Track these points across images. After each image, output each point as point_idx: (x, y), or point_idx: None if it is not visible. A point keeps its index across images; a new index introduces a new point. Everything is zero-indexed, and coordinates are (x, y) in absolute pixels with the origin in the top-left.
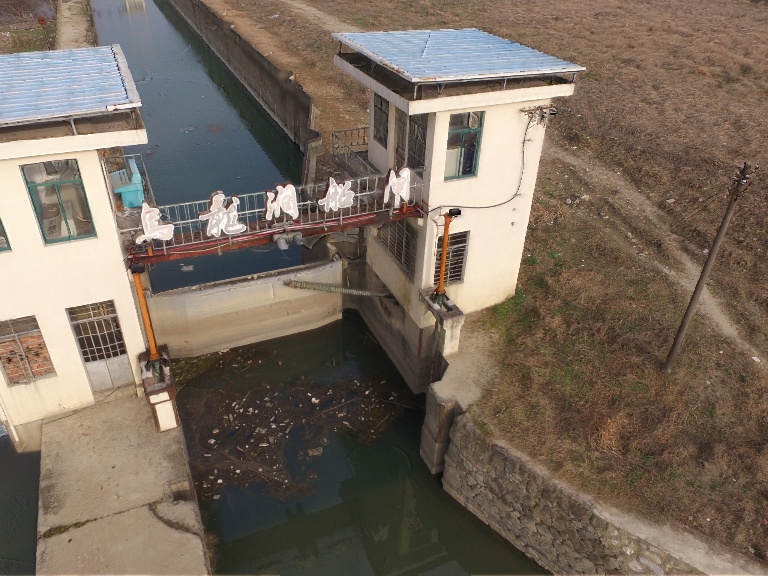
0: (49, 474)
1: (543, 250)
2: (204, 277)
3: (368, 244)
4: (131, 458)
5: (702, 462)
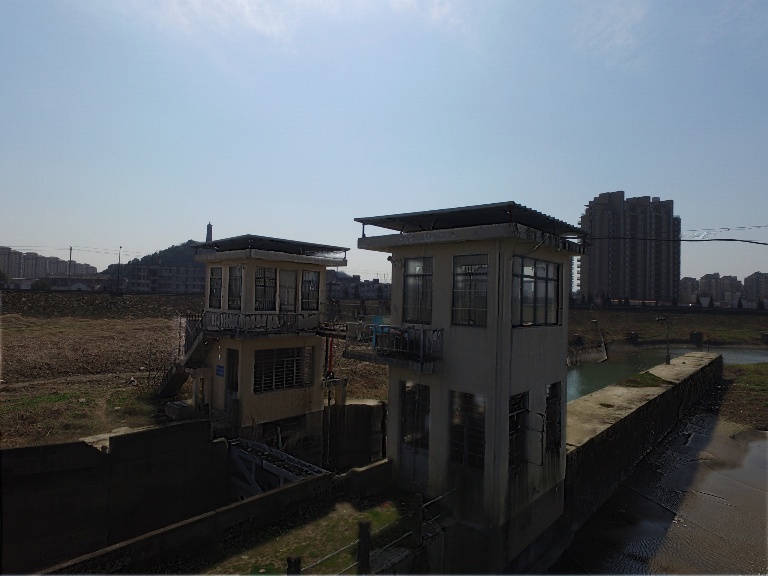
0: None
1: None
2: None
3: (247, 407)
4: None
5: None
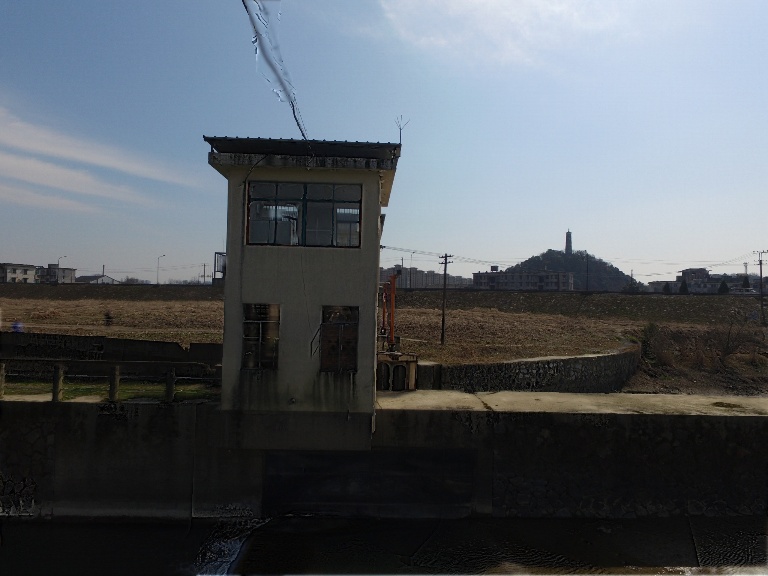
0: (437, 407)
1: None
2: None
3: None
4: (435, 395)
5: (490, 352)
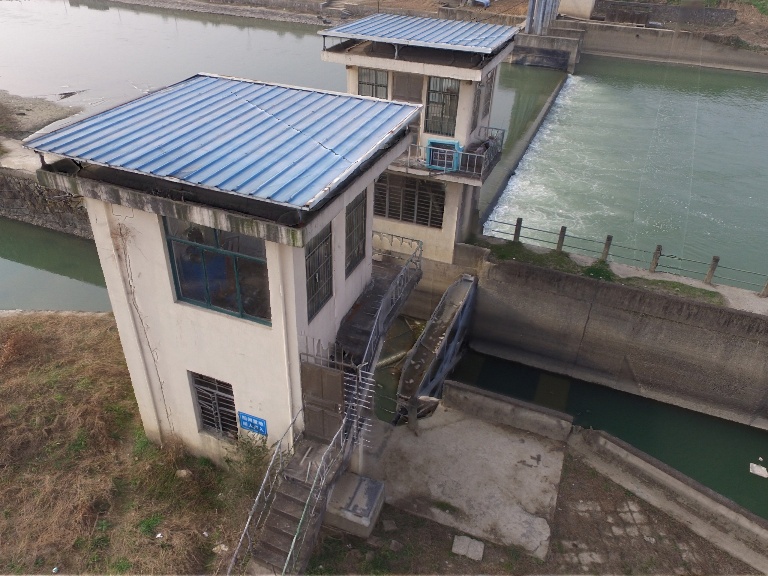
0: None
1: (140, 567)
2: (596, 423)
3: None
4: None
5: None
